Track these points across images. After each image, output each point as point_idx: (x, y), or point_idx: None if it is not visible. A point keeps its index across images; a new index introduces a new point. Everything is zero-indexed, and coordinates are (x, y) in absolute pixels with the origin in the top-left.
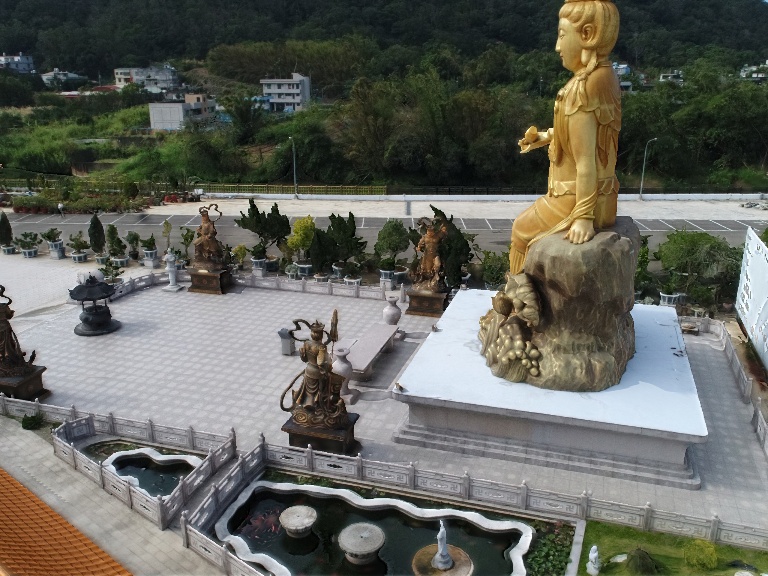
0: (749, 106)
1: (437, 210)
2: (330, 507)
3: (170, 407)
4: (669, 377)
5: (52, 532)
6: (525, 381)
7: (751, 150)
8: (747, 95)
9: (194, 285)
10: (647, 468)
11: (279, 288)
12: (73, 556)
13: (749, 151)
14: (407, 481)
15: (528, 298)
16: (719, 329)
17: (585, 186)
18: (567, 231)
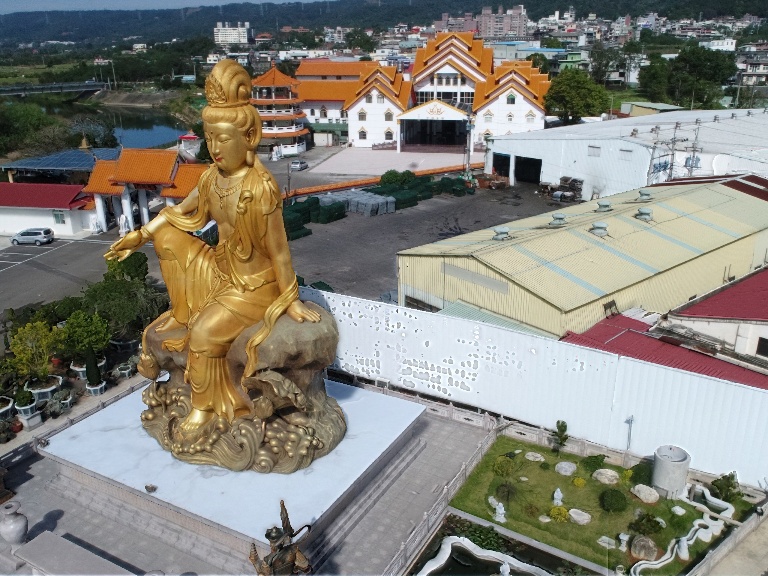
0: None
1: None
2: None
3: None
4: (338, 392)
5: None
6: (314, 459)
7: None
8: None
9: None
10: (407, 454)
11: None
12: None
13: None
14: None
15: (295, 388)
16: None
17: (291, 272)
18: (284, 316)
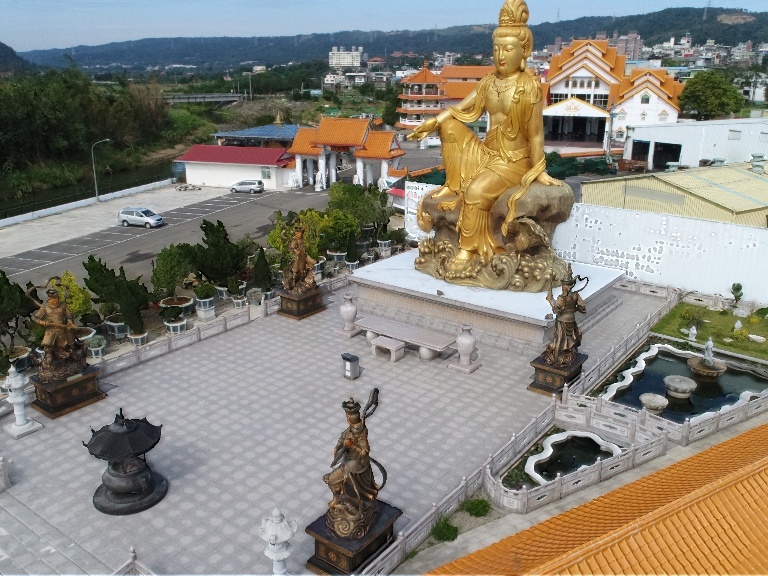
0: (16, 107)
1: (220, 222)
2: (617, 400)
3: (442, 445)
4: None
5: None
6: None
7: (26, 150)
8: (11, 96)
9: (58, 406)
10: None
11: (140, 361)
12: None
13: (25, 151)
14: (611, 362)
15: None
16: None
17: None
18: (535, 182)
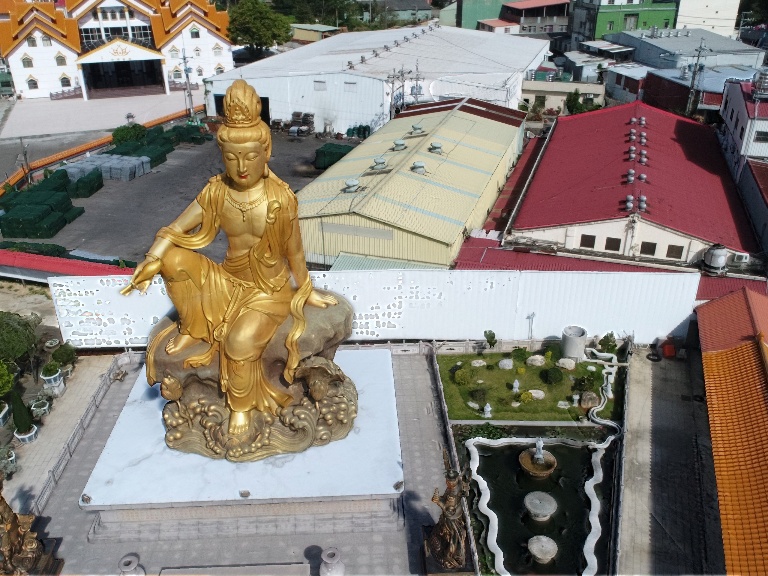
0: None
1: None
2: None
3: None
4: None
5: (745, 570)
6: None
7: None
8: None
9: None
10: None
11: None
12: (746, 541)
13: None
14: None
15: None
16: (127, 358)
17: None
18: (306, 306)
